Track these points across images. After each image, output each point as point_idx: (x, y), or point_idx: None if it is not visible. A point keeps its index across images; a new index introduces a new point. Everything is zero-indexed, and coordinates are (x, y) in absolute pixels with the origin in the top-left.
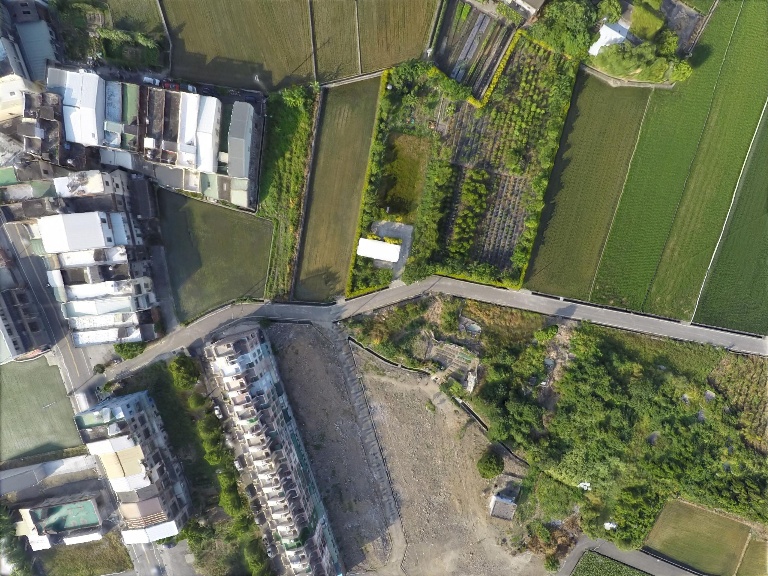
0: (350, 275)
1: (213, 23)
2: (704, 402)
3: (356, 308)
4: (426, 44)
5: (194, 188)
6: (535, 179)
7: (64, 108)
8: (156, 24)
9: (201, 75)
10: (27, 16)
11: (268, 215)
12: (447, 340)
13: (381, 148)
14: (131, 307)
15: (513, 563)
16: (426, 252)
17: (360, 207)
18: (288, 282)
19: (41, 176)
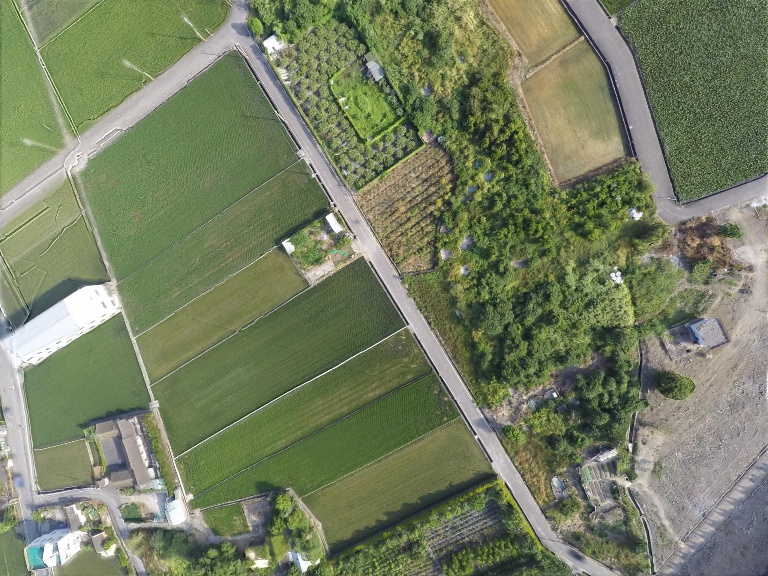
0: None
1: None
2: (455, 255)
3: None
4: None
5: None
6: None
7: None
8: None
9: None
10: None
11: None
12: None
13: None
14: None
15: (760, 259)
16: (535, 574)
17: None
18: None
19: None
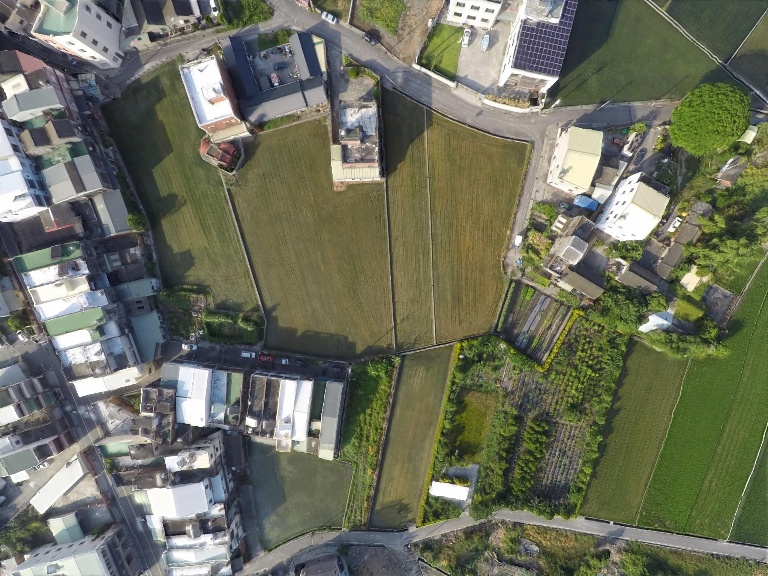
0: (422, 509)
1: (304, 303)
2: None
3: (426, 534)
4: (494, 320)
5: (286, 447)
6: (590, 432)
7: (177, 399)
8: (253, 305)
9: (292, 345)
10: (141, 311)
11: (348, 459)
12: (509, 562)
13: (454, 409)
14: (227, 555)
15: None
16: (492, 493)
17: (432, 452)
18: (365, 515)
19: (153, 455)
